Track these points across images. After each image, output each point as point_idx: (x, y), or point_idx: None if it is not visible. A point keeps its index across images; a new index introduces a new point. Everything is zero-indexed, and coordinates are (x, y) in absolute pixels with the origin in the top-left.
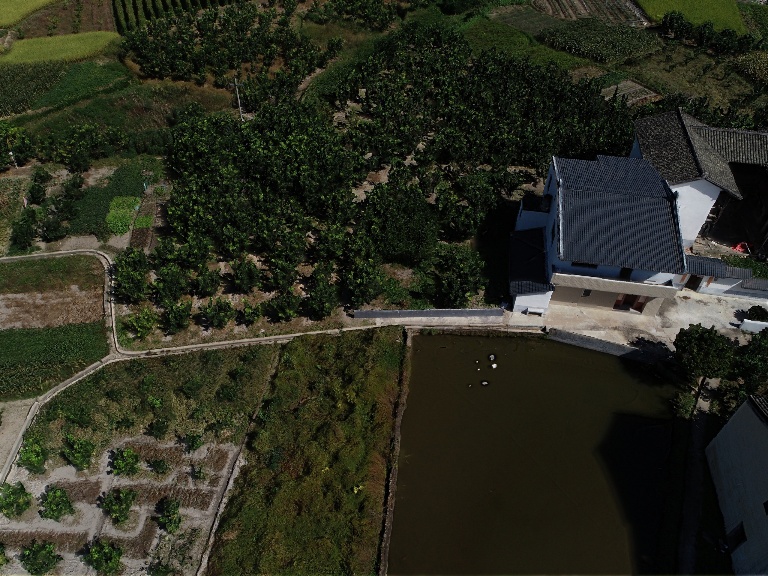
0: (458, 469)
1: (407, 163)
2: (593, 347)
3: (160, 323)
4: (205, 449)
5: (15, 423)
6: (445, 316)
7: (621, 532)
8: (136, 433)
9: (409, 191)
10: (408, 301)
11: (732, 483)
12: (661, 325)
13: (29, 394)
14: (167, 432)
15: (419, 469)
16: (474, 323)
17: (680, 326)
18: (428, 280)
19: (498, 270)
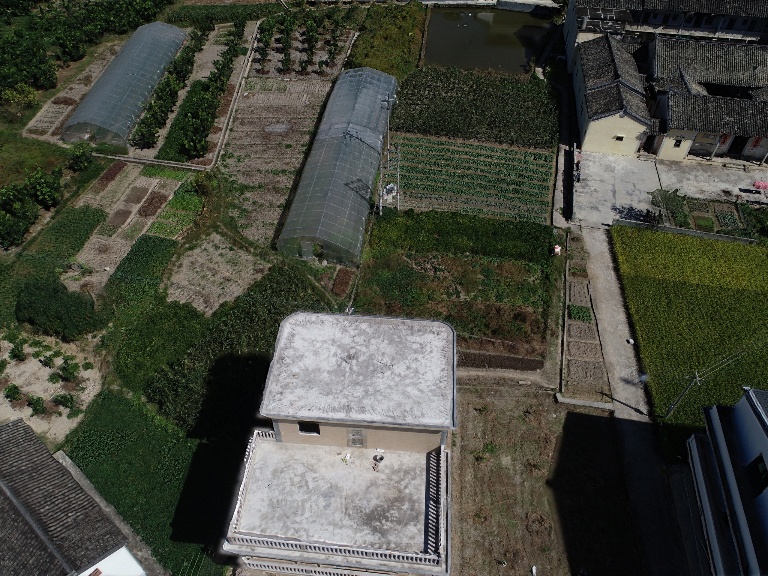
0: (453, 39)
1: None
2: (517, 9)
3: None
4: None
5: (252, 26)
6: (446, 1)
7: (522, 48)
8: None
9: None
10: None
11: (567, 23)
12: (551, 3)
13: (255, 19)
14: None
15: (436, 41)
16: None
17: (561, 4)
18: None
19: None
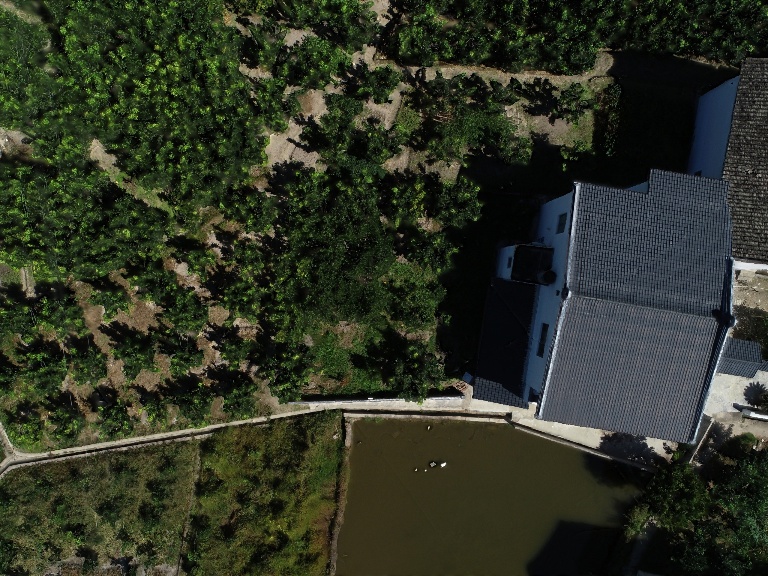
0: None
1: (356, 60)
2: None
3: (50, 409)
4: (142, 571)
5: None
6: None
7: None
8: (68, 555)
9: (351, 196)
10: (349, 372)
11: None
12: None
13: None
14: (99, 556)
15: (356, 573)
16: (427, 407)
17: None
18: (375, 337)
19: (469, 316)
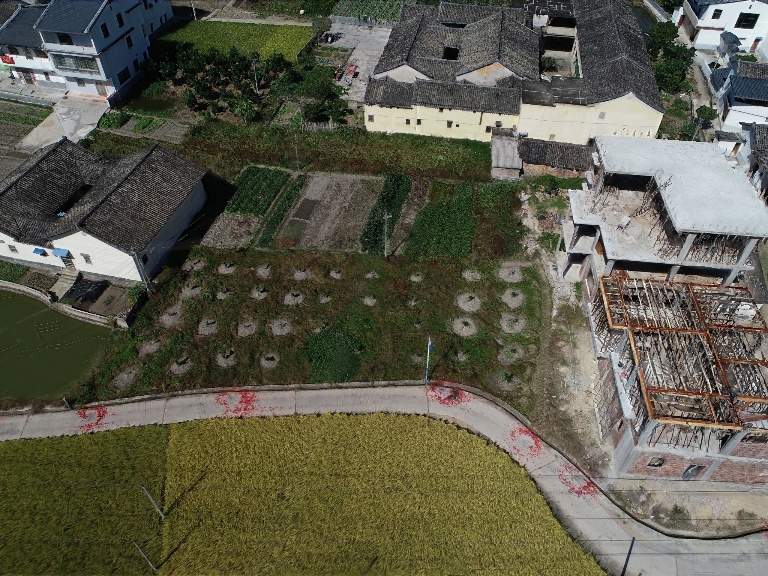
0: None
1: None
2: None
3: None
4: None
5: None
6: None
7: None
8: None
9: None
10: (660, 4)
11: None
12: None
13: None
14: None
15: None
16: None
17: None
18: None
19: None
